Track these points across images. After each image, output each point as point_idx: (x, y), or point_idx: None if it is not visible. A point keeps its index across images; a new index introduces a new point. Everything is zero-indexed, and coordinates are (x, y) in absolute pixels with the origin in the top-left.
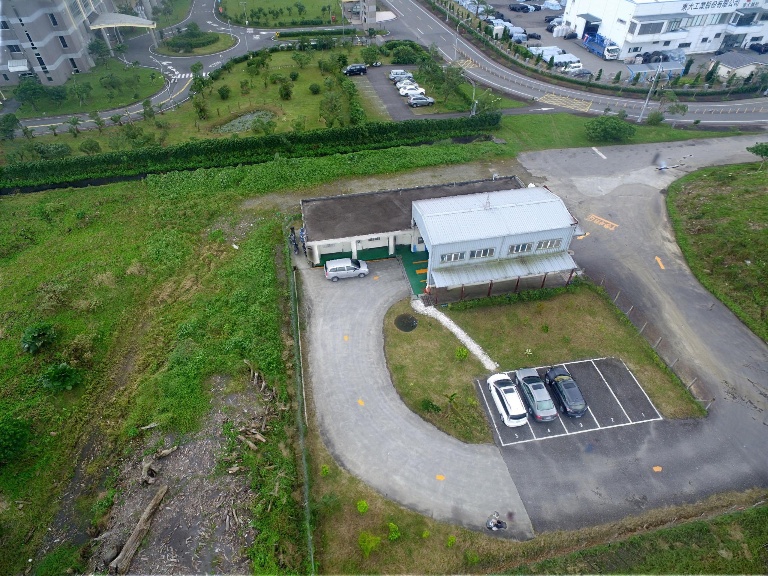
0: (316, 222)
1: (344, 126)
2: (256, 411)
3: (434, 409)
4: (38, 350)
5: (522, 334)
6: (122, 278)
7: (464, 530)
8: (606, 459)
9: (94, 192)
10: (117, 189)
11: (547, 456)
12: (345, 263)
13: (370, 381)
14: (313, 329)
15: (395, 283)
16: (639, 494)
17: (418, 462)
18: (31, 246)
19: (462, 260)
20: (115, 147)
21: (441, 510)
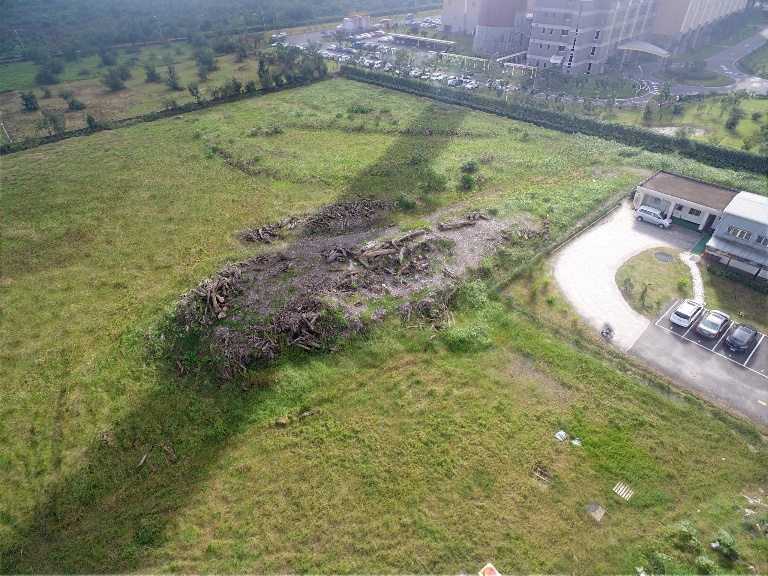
0: (658, 182)
1: (758, 153)
2: (533, 229)
3: (629, 284)
4: (466, 170)
5: (752, 308)
6: (522, 165)
7: (587, 324)
8: (725, 374)
9: (542, 130)
10: (555, 133)
11: (680, 345)
12: (655, 211)
13: (606, 260)
14: (599, 229)
15: (682, 241)
16: (726, 395)
17: (594, 295)
18: (494, 138)
19: (747, 241)
20: (572, 112)
21: (584, 312)
